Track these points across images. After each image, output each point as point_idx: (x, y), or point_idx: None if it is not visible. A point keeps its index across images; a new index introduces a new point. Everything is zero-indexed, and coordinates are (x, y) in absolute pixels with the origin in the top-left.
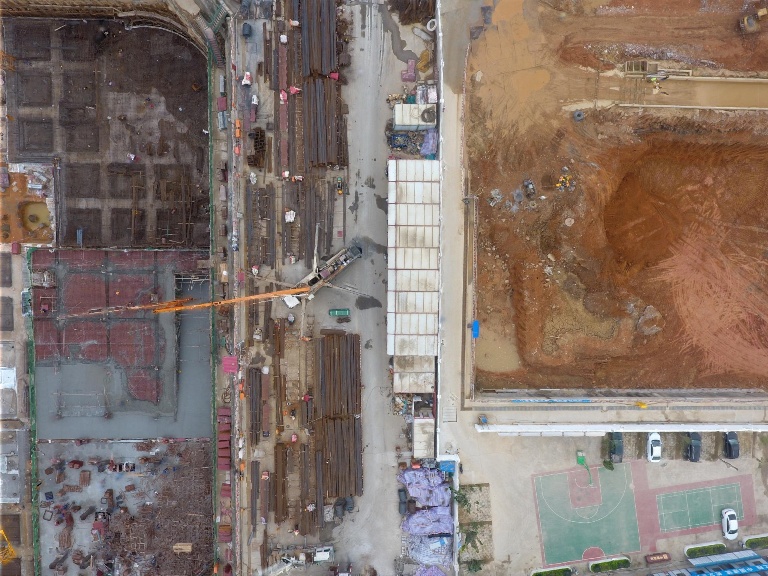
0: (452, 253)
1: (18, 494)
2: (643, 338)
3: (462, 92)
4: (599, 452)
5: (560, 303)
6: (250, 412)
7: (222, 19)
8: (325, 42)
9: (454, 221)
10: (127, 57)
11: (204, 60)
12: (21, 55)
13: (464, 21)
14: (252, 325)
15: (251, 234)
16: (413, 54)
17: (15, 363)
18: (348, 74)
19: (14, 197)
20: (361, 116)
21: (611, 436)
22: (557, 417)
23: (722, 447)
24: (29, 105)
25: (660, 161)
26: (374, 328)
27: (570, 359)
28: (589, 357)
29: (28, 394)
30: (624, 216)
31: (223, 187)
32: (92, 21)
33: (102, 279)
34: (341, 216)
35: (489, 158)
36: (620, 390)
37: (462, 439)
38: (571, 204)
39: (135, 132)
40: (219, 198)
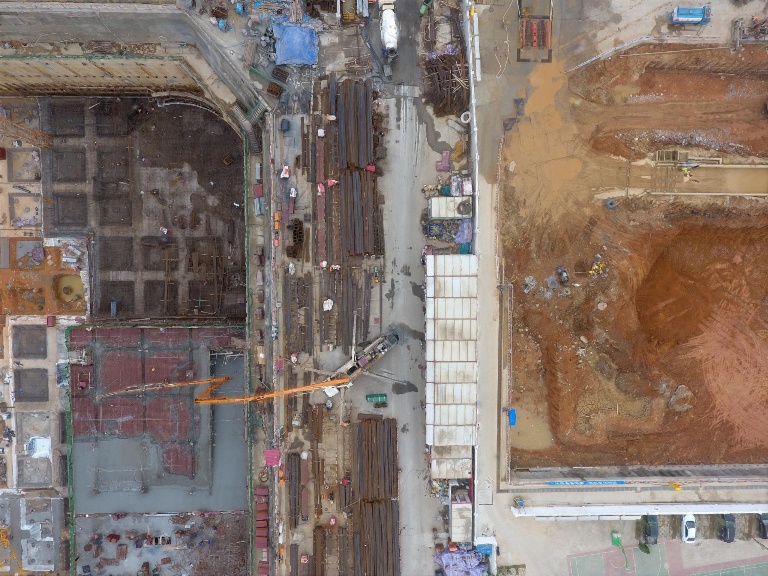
0: (487, 339)
1: (53, 561)
2: (674, 415)
3: (496, 182)
4: (634, 533)
5: (593, 383)
6: (289, 496)
7: (261, 114)
8: (362, 136)
9: (489, 308)
10: (159, 133)
11: (235, 135)
12: (56, 132)
13: (497, 113)
14: (291, 411)
15: (290, 323)
16: (447, 145)
17: (50, 433)
18: (384, 165)
19: (49, 270)
20: (397, 206)
21: (646, 518)
22: (592, 498)
23: (755, 526)
24: (64, 181)
25: (689, 240)
26: (410, 412)
27: (603, 438)
28: (621, 434)
29: (63, 463)
30: (655, 297)
31: (260, 272)
32: (125, 99)
33: (138, 356)
34: (377, 303)
35: (523, 246)
36: (652, 467)
37: (498, 521)
38: (604, 289)
39: (167, 206)
40: (256, 283)
